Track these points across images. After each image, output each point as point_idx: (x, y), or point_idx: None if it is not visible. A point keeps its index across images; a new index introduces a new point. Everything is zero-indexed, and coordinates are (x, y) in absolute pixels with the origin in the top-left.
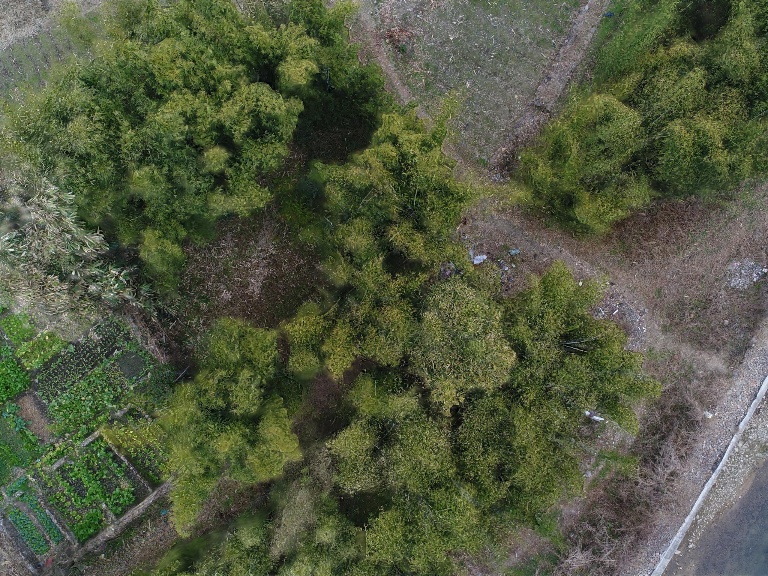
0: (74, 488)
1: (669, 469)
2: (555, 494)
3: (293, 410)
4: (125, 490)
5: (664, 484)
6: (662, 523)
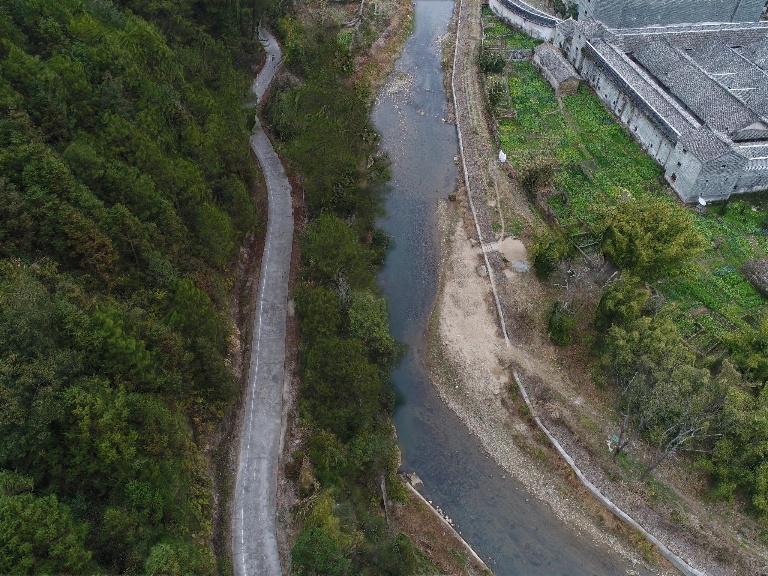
0: (674, 319)
1: (767, 573)
2: (763, 479)
3: (760, 382)
4: (680, 335)
5: (754, 573)
6: (727, 573)
